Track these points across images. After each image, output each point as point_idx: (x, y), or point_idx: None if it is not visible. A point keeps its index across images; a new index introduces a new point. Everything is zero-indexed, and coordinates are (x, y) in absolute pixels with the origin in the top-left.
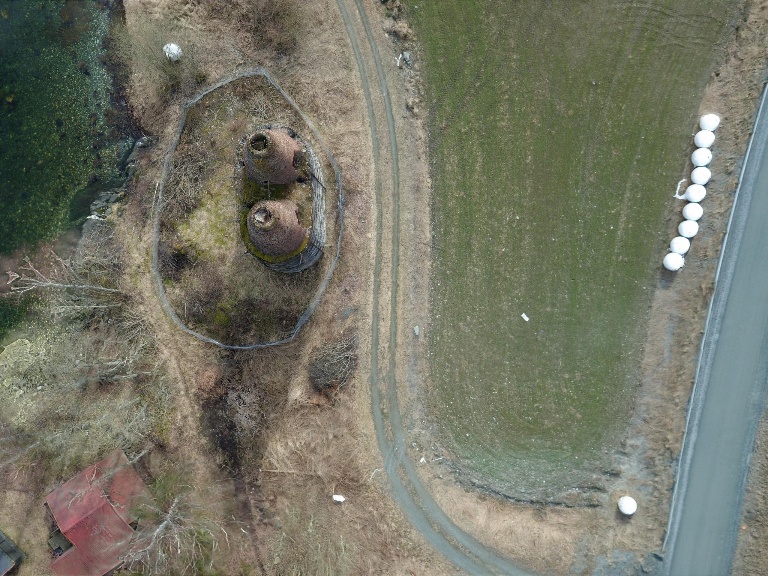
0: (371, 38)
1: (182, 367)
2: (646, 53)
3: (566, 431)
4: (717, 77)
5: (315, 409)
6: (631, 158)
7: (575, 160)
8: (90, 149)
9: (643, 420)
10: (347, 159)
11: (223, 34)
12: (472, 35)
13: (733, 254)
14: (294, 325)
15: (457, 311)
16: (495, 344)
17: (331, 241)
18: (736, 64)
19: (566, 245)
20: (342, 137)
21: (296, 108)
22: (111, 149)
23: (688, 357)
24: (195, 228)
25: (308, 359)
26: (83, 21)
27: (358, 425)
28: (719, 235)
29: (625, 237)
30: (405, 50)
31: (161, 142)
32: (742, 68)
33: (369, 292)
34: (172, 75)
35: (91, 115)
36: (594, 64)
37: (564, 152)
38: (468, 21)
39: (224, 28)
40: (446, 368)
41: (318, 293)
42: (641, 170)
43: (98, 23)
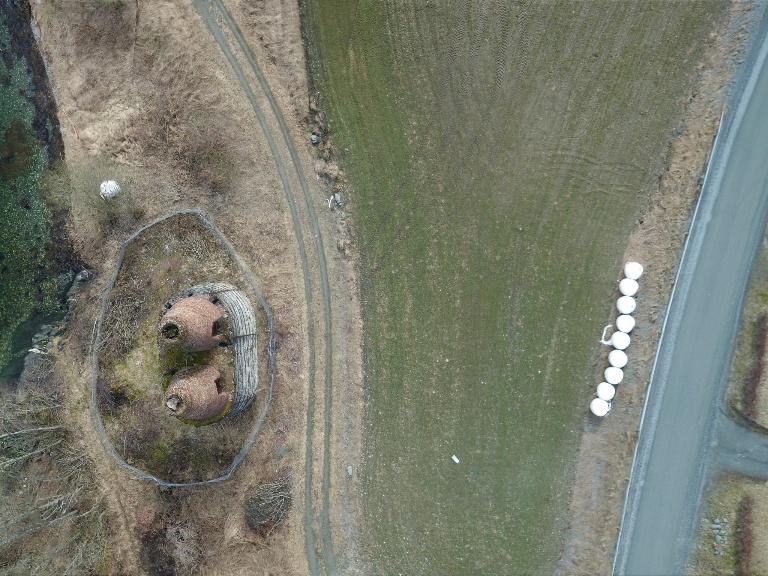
0: (303, 180)
1: (122, 501)
2: (571, 200)
3: (497, 572)
4: (641, 224)
5: (251, 547)
6: (558, 303)
7: (503, 305)
8: (31, 282)
9: (572, 562)
10: (279, 301)
11: (160, 171)
12: (401, 179)
13: (657, 402)
14: (230, 464)
15: (389, 452)
16: (426, 485)
17: (264, 384)
18: (659, 212)
19: (495, 388)
20: (274, 279)
21: (230, 248)
22: (52, 282)
23: (614, 503)
24: (131, 369)
25: (244, 497)
26: (23, 156)
27: (292, 565)
28: (643, 383)
29: (552, 381)
30: (336, 192)
31: (100, 277)
32: (665, 217)
33: (302, 433)
34: (110, 212)
35: (32, 249)
36: (520, 210)
37: (492, 297)
38: (397, 165)
39: (160, 165)
40: (379, 508)
41: (252, 434)
42: (567, 315)
43: (38, 158)
